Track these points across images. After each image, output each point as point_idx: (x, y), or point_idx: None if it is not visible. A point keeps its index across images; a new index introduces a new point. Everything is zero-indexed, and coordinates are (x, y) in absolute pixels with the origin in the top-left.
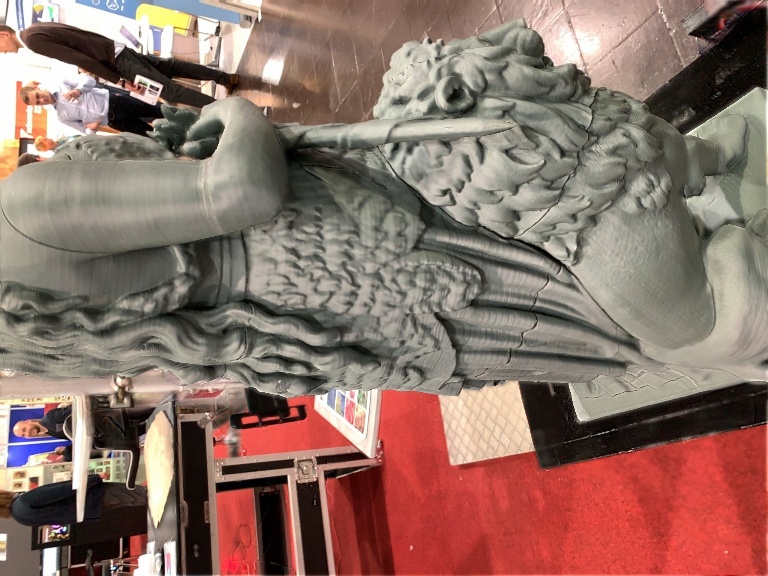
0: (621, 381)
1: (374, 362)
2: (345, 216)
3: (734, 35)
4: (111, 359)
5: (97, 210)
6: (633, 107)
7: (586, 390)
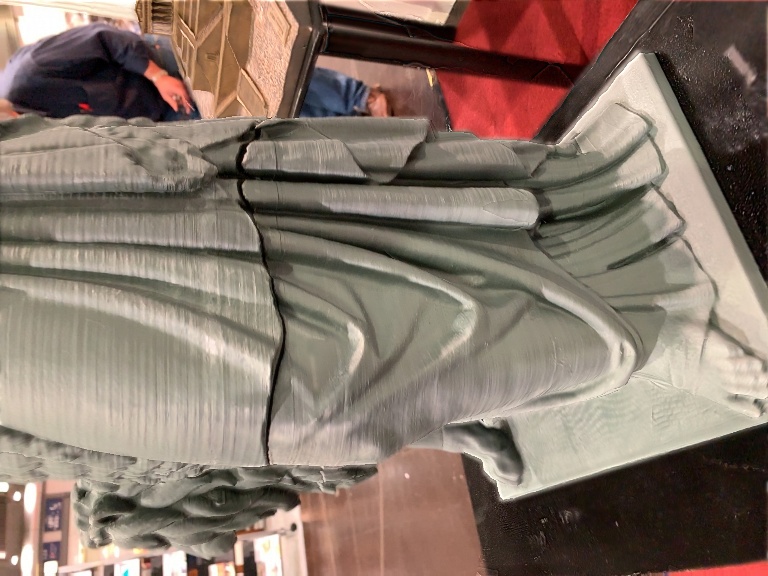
0: None
1: None
2: None
3: (532, 575)
4: None
5: None
6: None
7: None
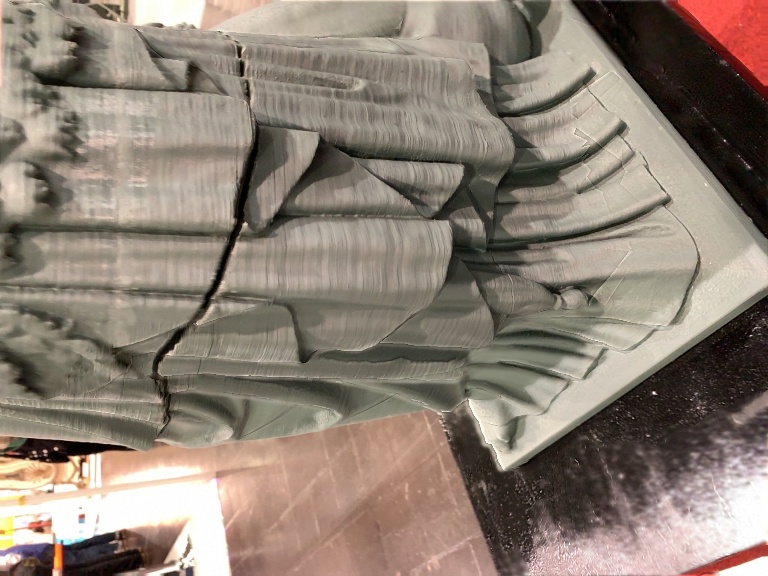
0: (619, 177)
1: None
2: None
3: None
4: None
5: None
6: None
7: (661, 243)
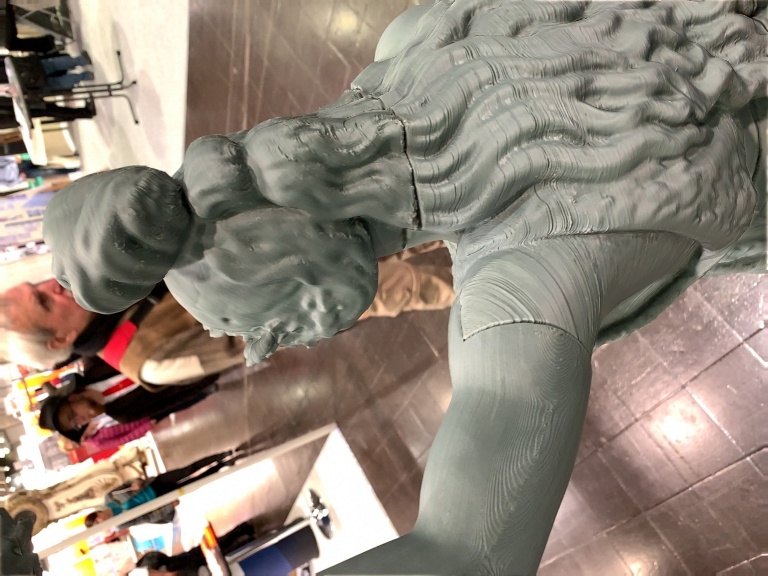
0: None
1: None
2: None
3: None
4: (621, 1)
5: None
6: None
7: None
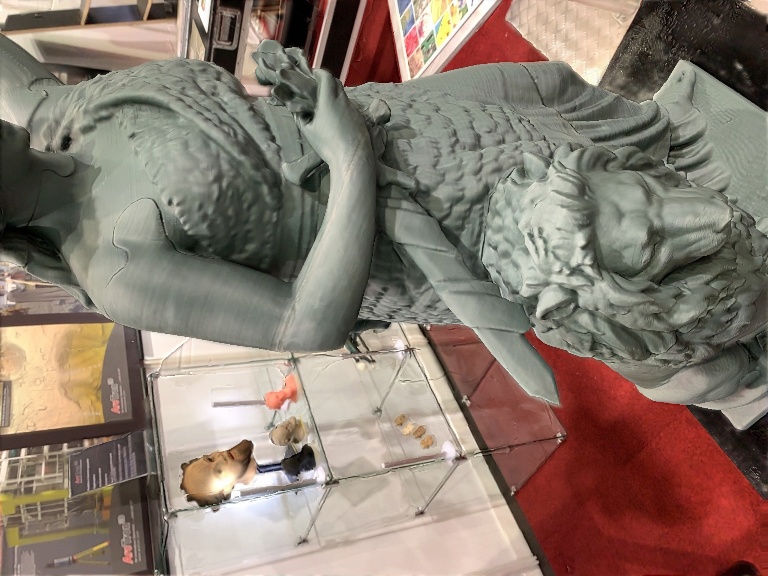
0: None
1: (386, 326)
2: (406, 297)
3: None
4: None
5: (186, 334)
6: (732, 326)
7: None
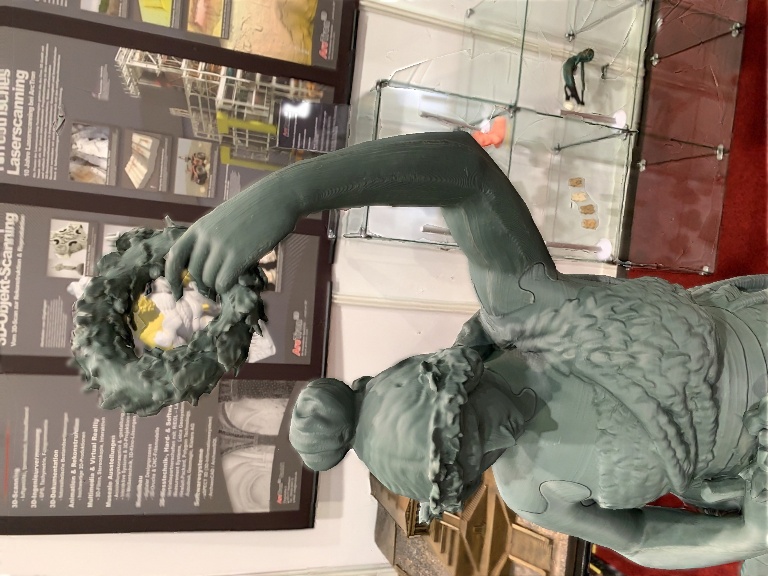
0: None
1: None
2: None
3: None
4: None
5: None
6: None
7: None
